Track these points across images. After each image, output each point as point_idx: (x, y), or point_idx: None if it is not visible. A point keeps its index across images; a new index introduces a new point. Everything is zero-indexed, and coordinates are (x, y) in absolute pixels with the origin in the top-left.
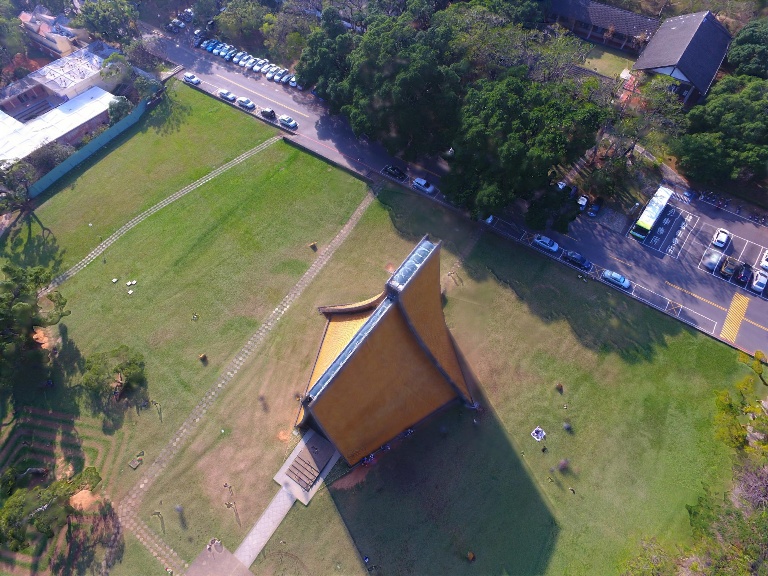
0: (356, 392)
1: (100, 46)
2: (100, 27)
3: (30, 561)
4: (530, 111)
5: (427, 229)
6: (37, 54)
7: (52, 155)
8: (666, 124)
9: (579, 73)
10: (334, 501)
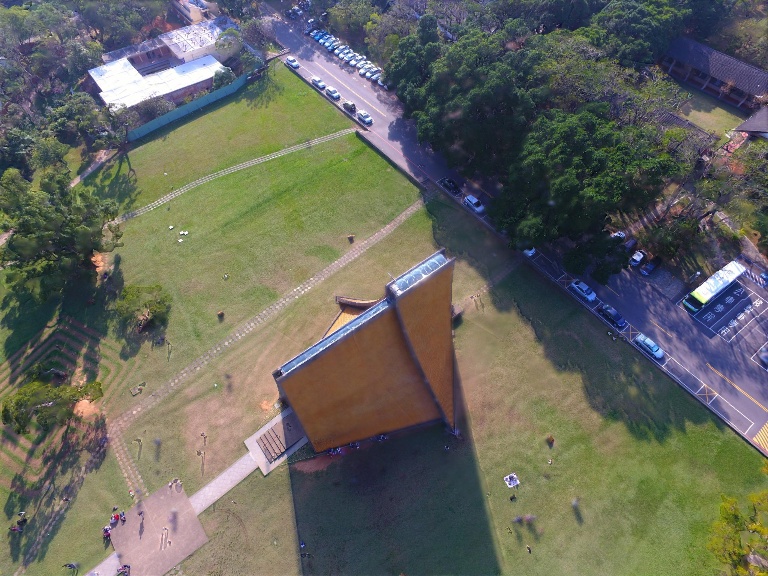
0: (334, 382)
1: (225, 20)
2: (227, 3)
3: (29, 447)
4: (596, 150)
5: (465, 247)
6: (174, 19)
7: (156, 108)
8: (750, 193)
9: (675, 123)
10: (291, 480)
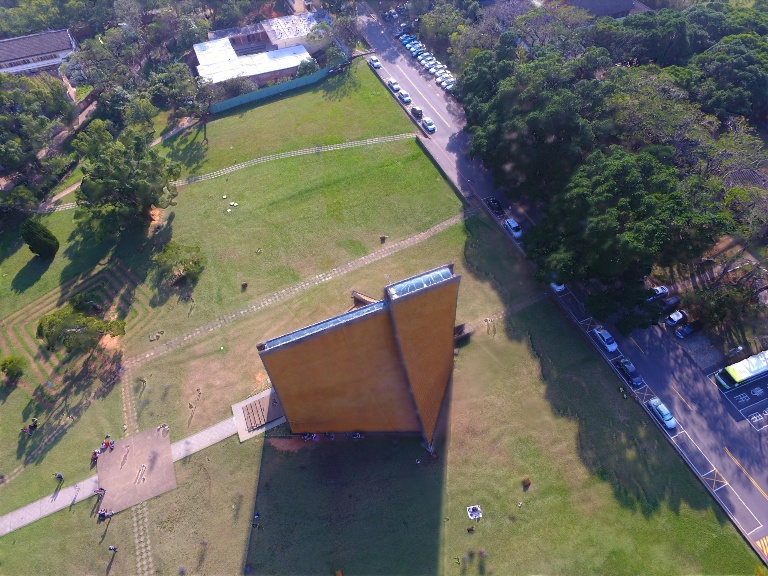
0: (318, 369)
1: (323, 15)
2: None
3: (56, 364)
4: (647, 194)
5: (492, 269)
6: (281, 8)
7: (240, 86)
8: None
9: (757, 182)
10: (263, 452)
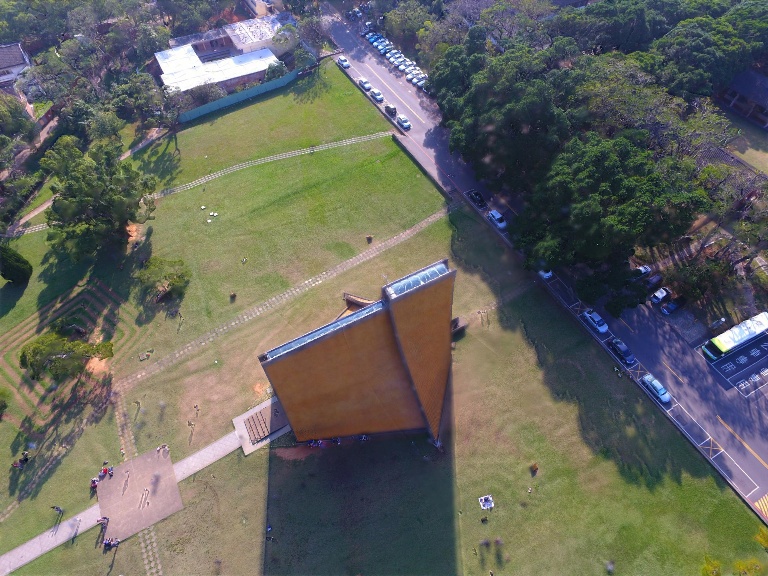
0: (320, 375)
1: (287, 16)
2: (291, 0)
3: (42, 393)
4: (626, 178)
5: (481, 261)
6: (241, 12)
7: (208, 93)
8: None
9: (724, 159)
10: (269, 464)
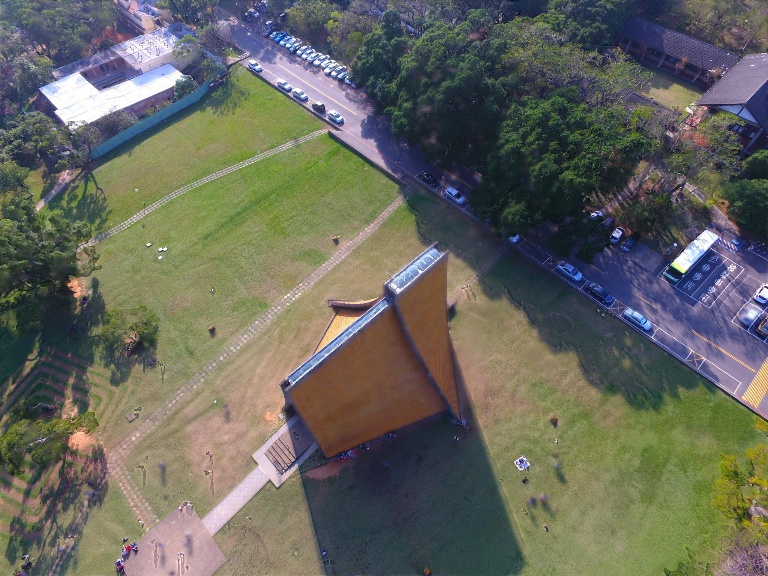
0: (340, 386)
1: (179, 27)
2: (181, 10)
3: (25, 487)
4: (571, 133)
5: (450, 239)
6: (125, 29)
7: (117, 122)
8: (718, 164)
9: (638, 101)
10: (304, 489)
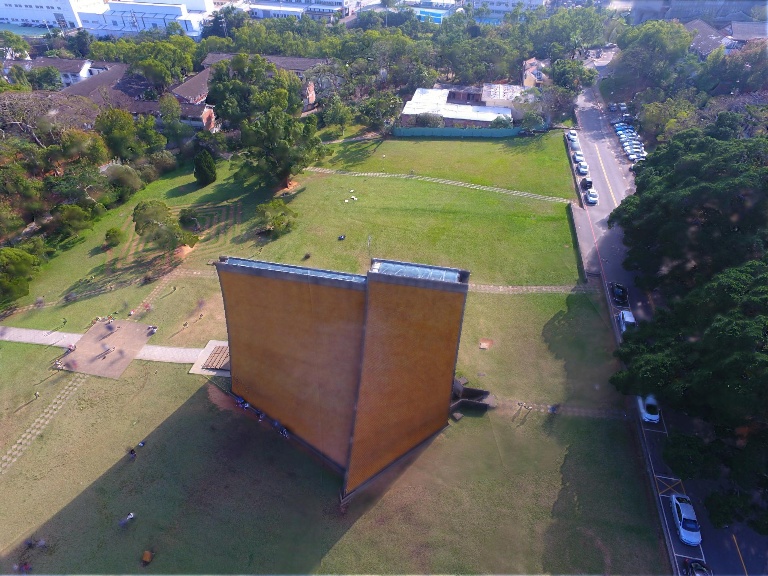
0: (273, 324)
1: None
2: (555, 76)
3: (139, 250)
4: None
5: (569, 355)
6: None
7: (430, 121)
8: None
9: None
10: (196, 392)
